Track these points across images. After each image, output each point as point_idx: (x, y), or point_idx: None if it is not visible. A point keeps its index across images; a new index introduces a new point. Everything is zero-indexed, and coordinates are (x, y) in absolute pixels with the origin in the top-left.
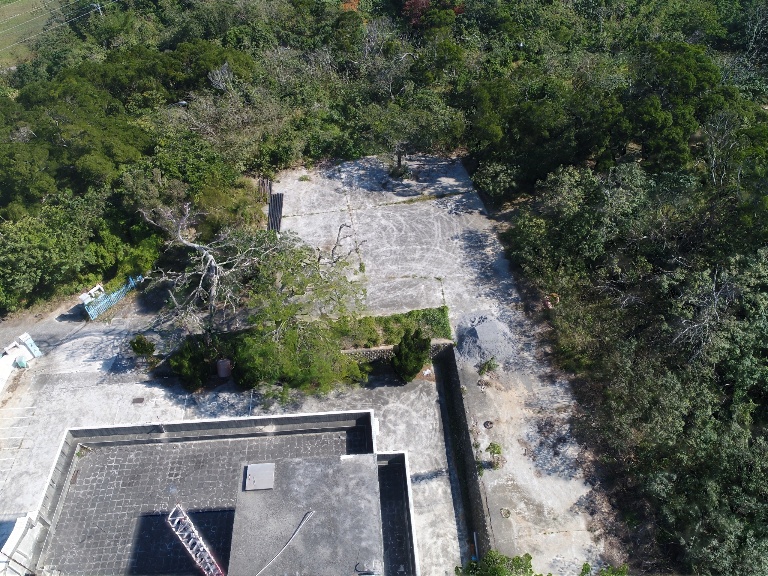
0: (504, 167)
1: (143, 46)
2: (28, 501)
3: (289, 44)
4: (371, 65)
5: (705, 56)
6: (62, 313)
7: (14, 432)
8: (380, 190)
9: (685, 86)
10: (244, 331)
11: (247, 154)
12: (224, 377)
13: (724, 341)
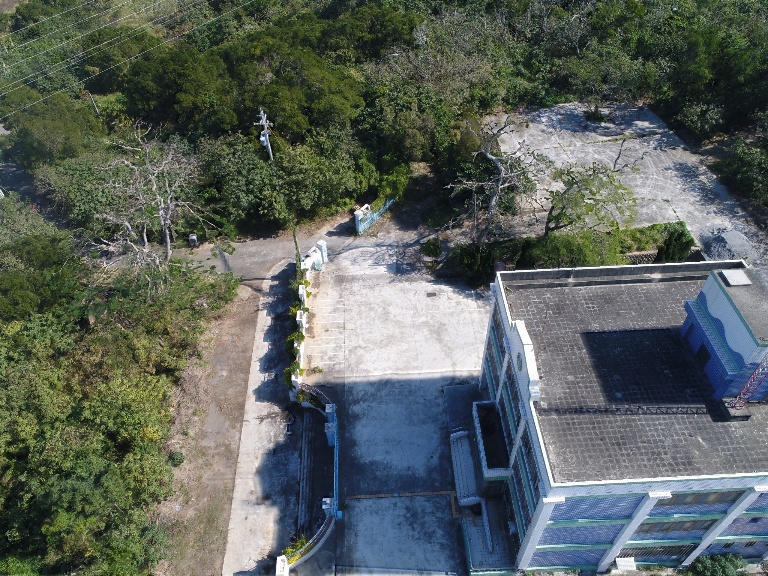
0: (711, 106)
1: None
2: (371, 367)
3: (440, 13)
4: (538, 27)
5: None
6: (329, 230)
7: (334, 317)
8: (583, 131)
9: None
10: (507, 241)
11: None
12: None
13: None
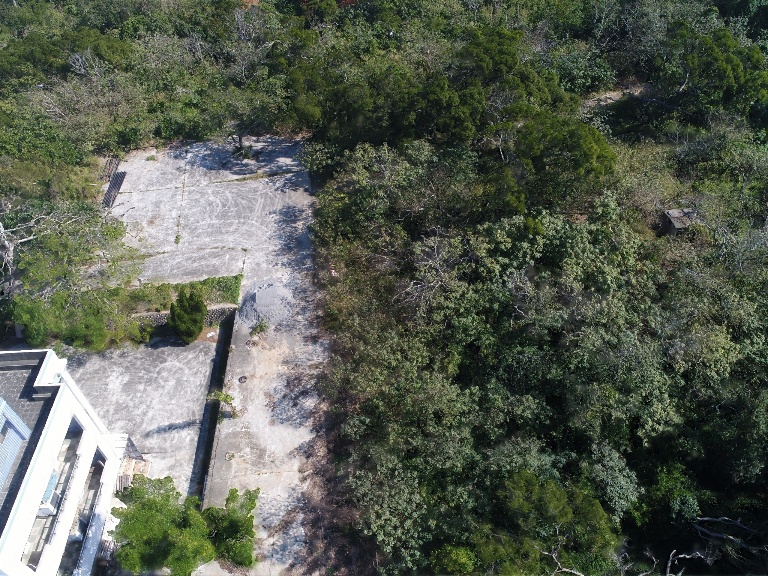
0: (321, 146)
1: (38, 35)
2: None
3: (184, 34)
4: None
5: (507, 40)
6: None
7: None
8: (219, 169)
9: (480, 68)
10: None
11: (95, 134)
12: (21, 338)
13: (453, 301)
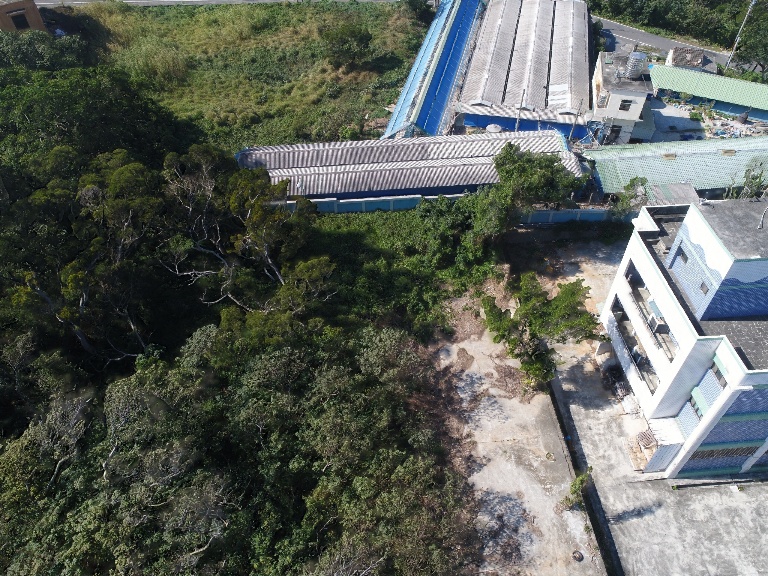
0: None
1: None
2: None
3: None
4: None
5: None
6: None
7: None
8: None
9: None
10: None
11: None
12: None
13: None
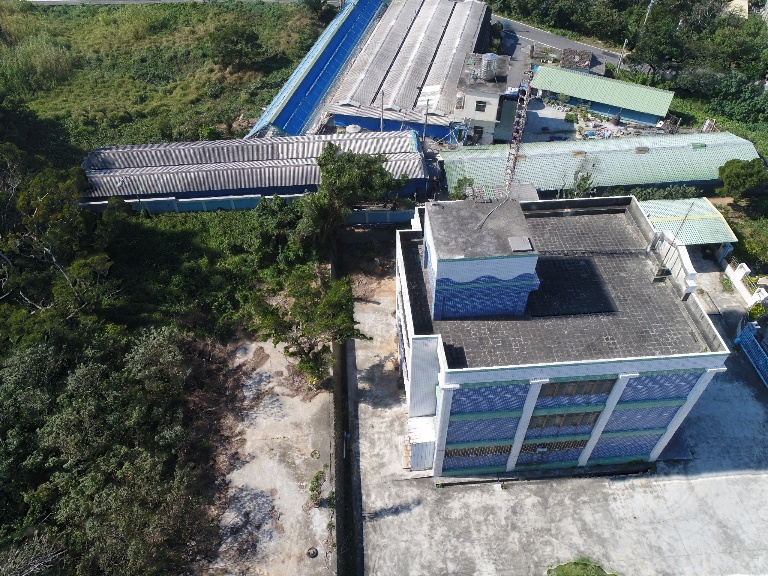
0: None
1: None
2: None
3: None
4: None
5: None
6: None
7: None
8: None
9: None
10: None
11: None
12: None
13: None
